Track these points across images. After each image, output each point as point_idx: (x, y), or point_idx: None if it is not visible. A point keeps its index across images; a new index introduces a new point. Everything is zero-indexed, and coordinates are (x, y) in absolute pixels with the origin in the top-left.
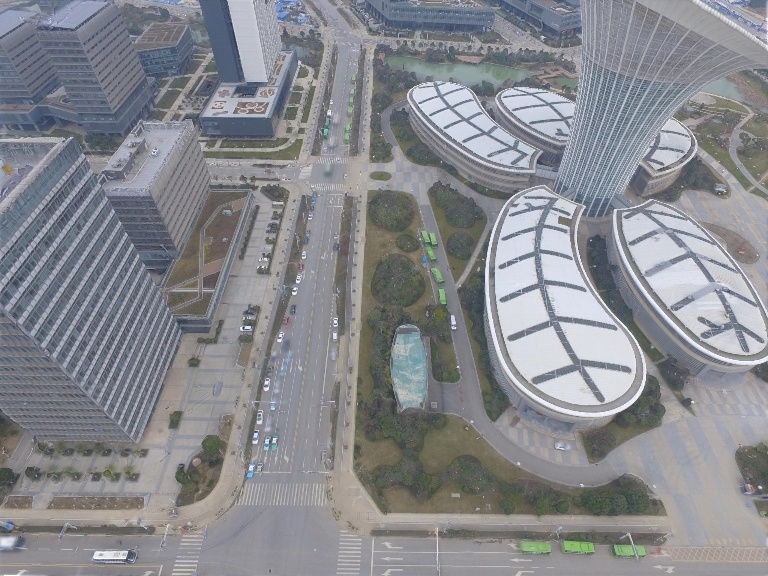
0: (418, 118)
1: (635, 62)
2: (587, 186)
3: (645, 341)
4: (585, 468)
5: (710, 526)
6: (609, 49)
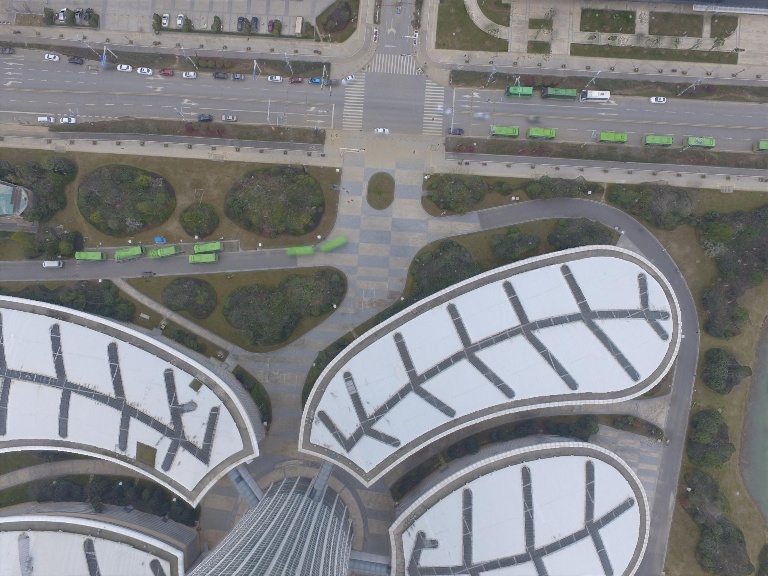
0: None
1: None
2: None
3: (2, 500)
4: None
5: None
6: None
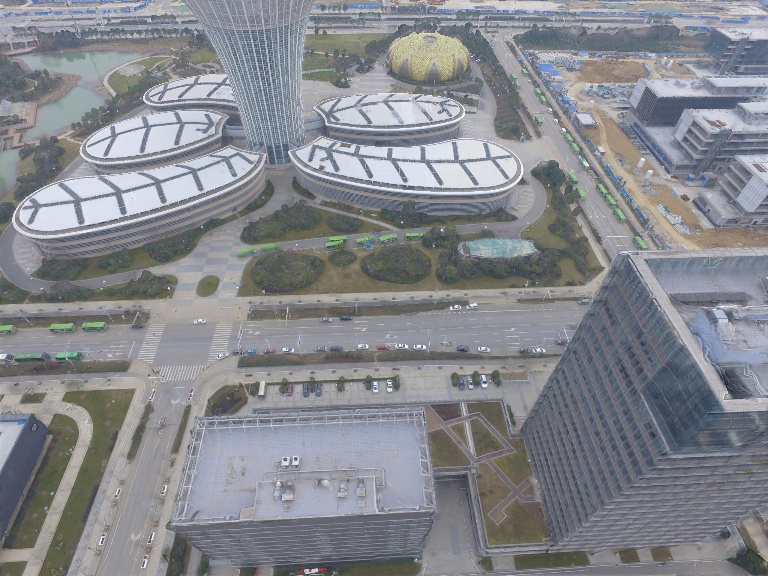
0: (106, 234)
1: (298, 8)
2: (298, 129)
3: None
4: (533, 187)
5: (545, 155)
6: (279, 9)
